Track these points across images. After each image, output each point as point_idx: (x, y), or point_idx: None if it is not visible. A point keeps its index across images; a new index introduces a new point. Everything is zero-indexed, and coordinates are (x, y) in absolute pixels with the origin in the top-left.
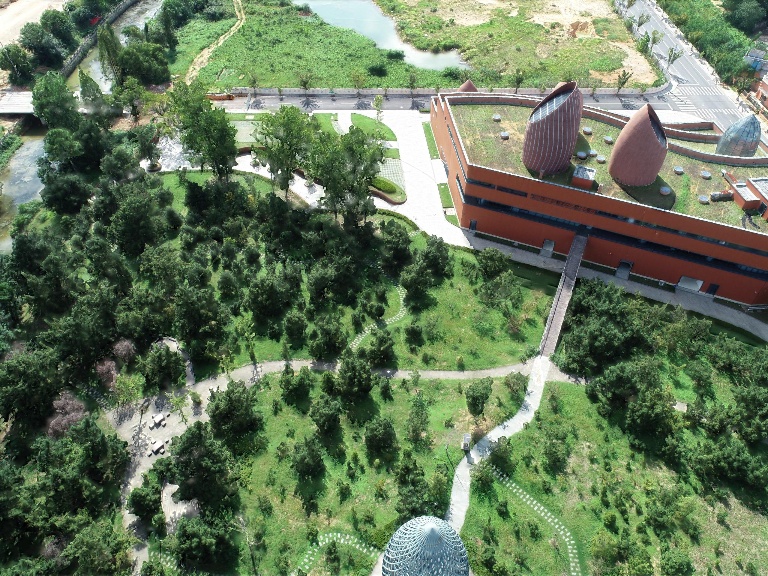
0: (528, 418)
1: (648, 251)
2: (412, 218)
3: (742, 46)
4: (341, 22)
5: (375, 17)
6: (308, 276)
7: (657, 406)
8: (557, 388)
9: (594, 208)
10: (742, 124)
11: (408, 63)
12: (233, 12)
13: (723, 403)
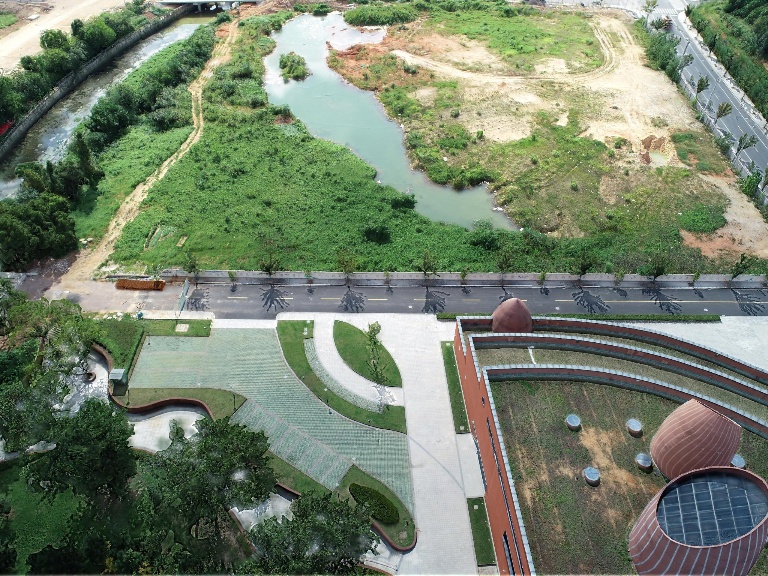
0: None
1: None
2: None
3: None
4: (331, 131)
5: (377, 121)
6: None
7: None
8: None
9: None
10: None
11: (420, 209)
12: (187, 117)
13: None
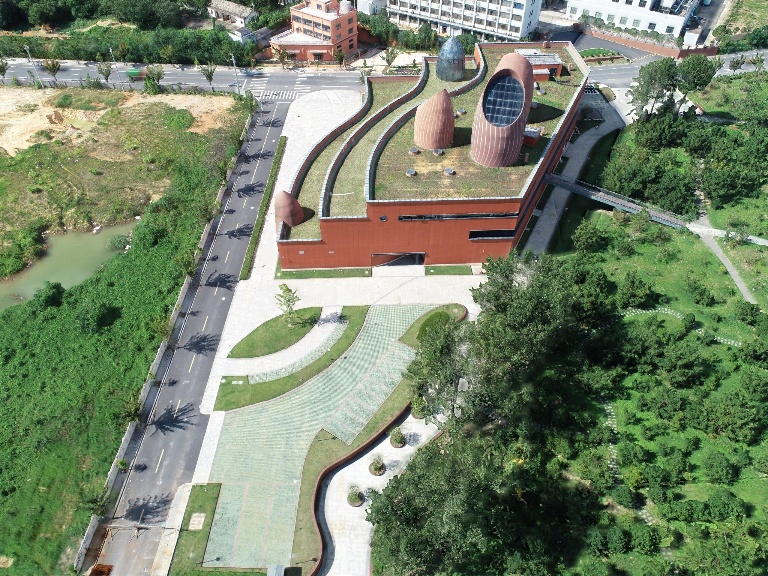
0: (761, 240)
1: None
2: None
3: None
4: None
5: None
6: (683, 371)
7: (740, 170)
8: (737, 215)
9: None
10: (456, 46)
11: None
12: None
13: (682, 159)
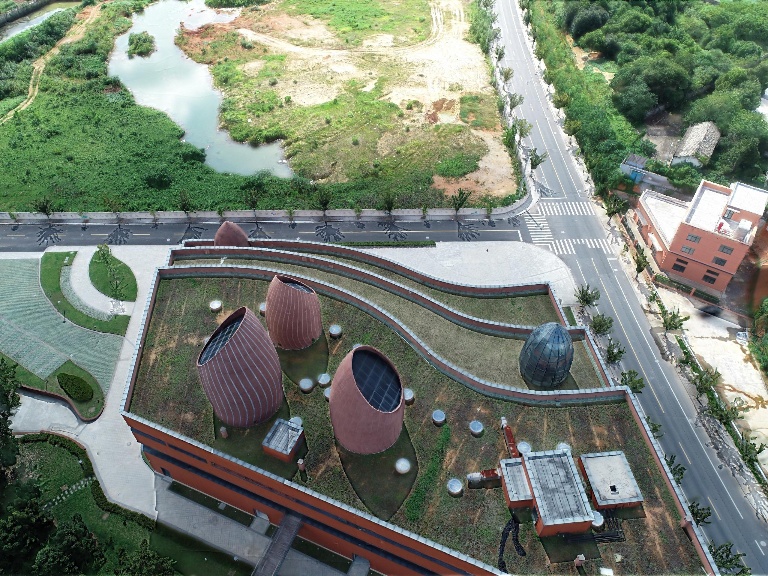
0: None
1: (380, 556)
2: (93, 452)
3: (623, 146)
4: (157, 99)
5: (204, 90)
6: None
7: None
8: None
9: (292, 496)
10: (542, 337)
11: (213, 163)
12: (22, 88)
13: None
